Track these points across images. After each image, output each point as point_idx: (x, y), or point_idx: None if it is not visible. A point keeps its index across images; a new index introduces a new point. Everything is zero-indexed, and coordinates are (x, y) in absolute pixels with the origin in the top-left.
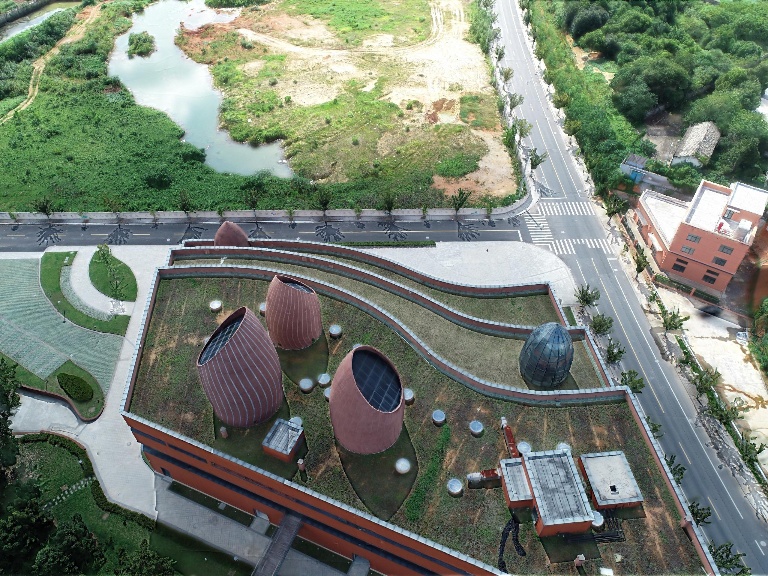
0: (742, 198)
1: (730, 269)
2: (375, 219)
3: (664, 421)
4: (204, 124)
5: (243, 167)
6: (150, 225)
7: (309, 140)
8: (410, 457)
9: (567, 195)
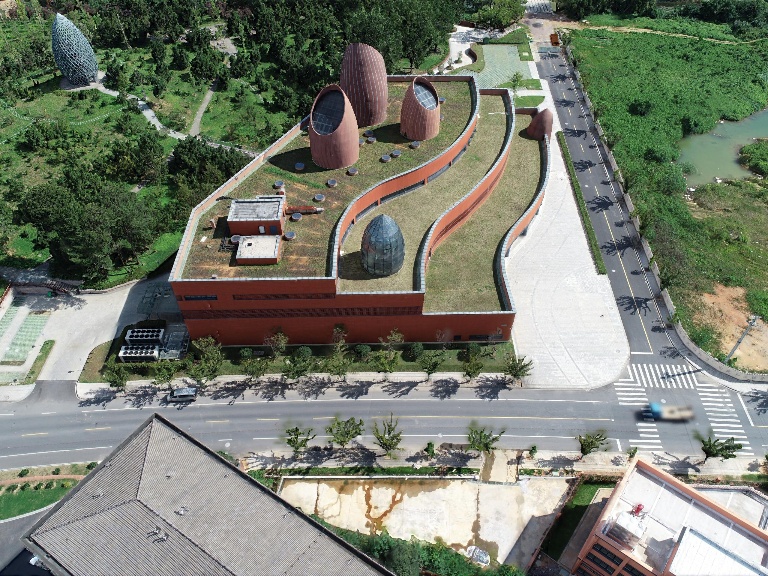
0: (724, 567)
1: (585, 549)
2: (632, 234)
3: (362, 413)
4: (760, 130)
5: (695, 157)
6: (582, 114)
7: (765, 191)
8: (306, 171)
9: (761, 428)
